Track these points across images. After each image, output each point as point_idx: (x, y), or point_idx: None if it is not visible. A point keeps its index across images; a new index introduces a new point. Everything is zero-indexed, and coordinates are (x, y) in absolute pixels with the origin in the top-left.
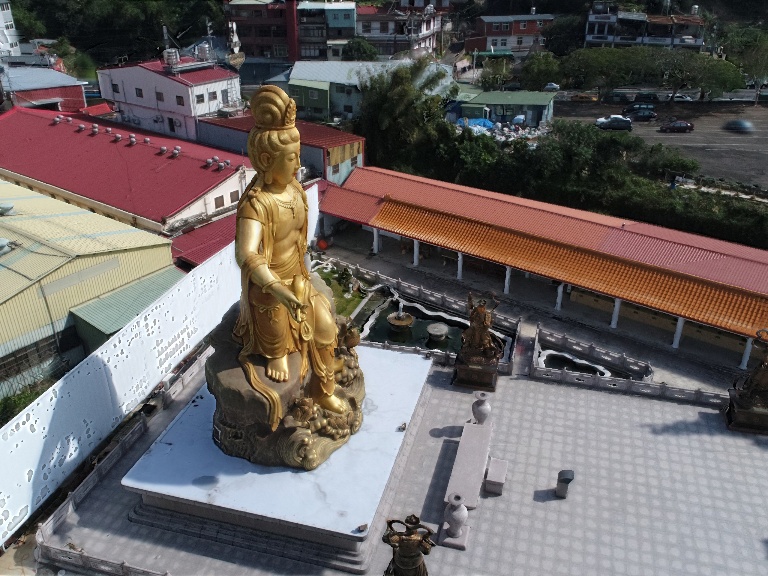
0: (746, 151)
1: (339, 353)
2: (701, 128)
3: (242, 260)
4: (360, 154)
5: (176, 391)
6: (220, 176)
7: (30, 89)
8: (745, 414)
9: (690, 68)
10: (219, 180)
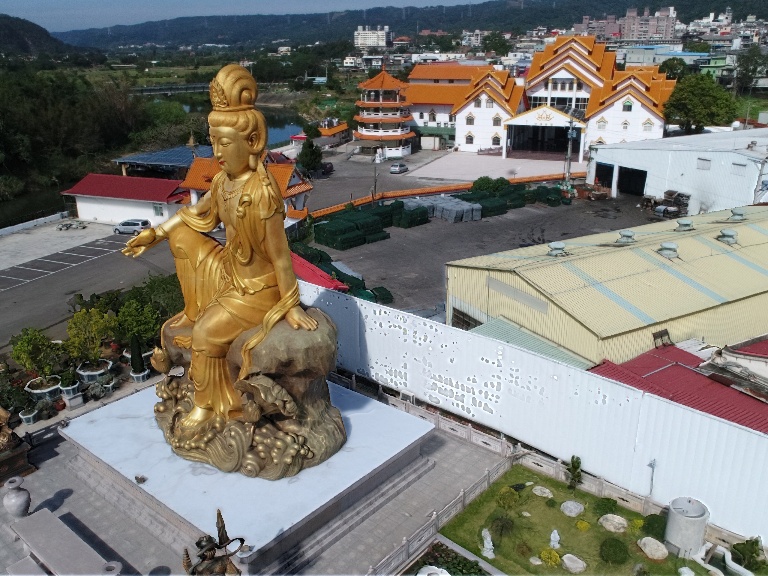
0: None
1: None
2: None
3: None
4: None
5: None
6: None
7: None
8: None
9: None
10: None
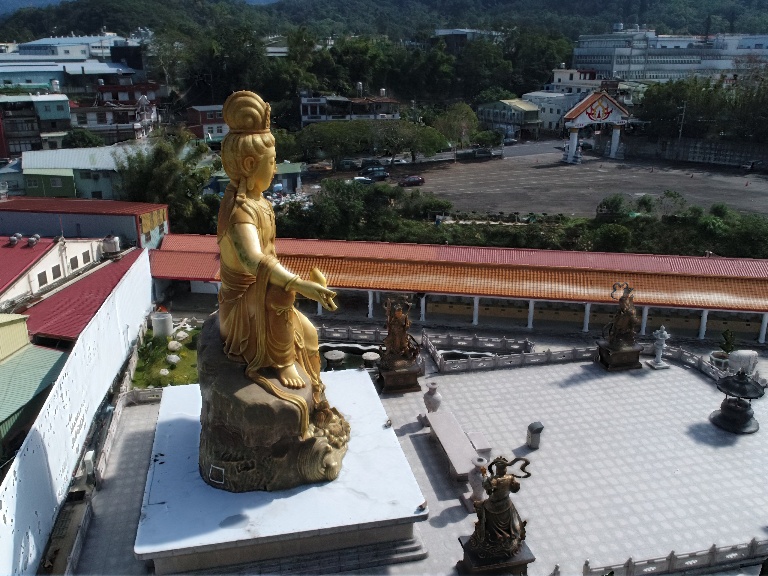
0: (473, 193)
1: None
2: (428, 181)
3: (256, 262)
4: (165, 221)
5: (102, 469)
6: (35, 251)
7: None
8: (617, 356)
9: (406, 134)
10: (38, 254)
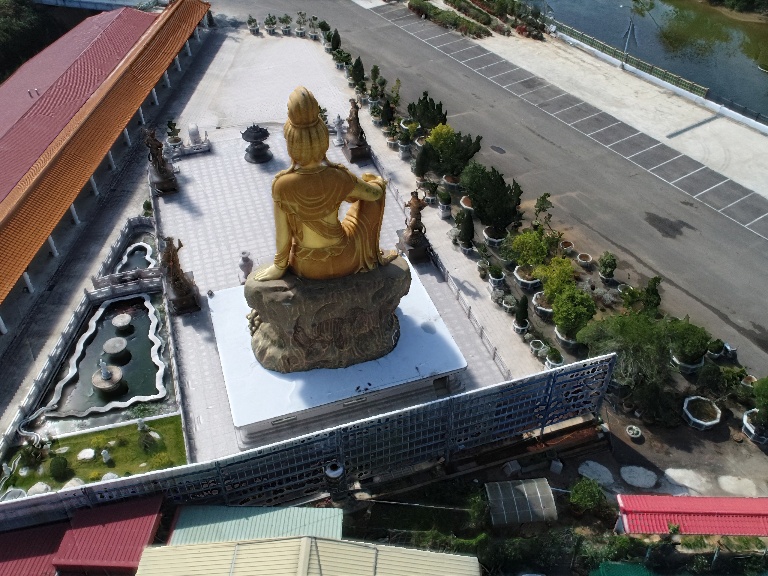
0: None
1: None
2: None
3: None
4: None
5: None
6: None
7: None
8: None
9: None
10: None
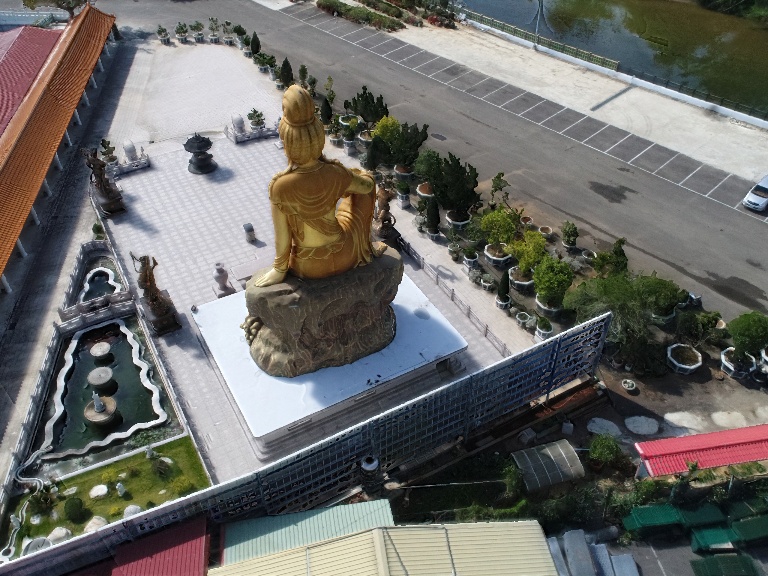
0: None
1: None
2: None
3: None
4: None
5: None
6: None
7: None
8: None
9: None
10: None
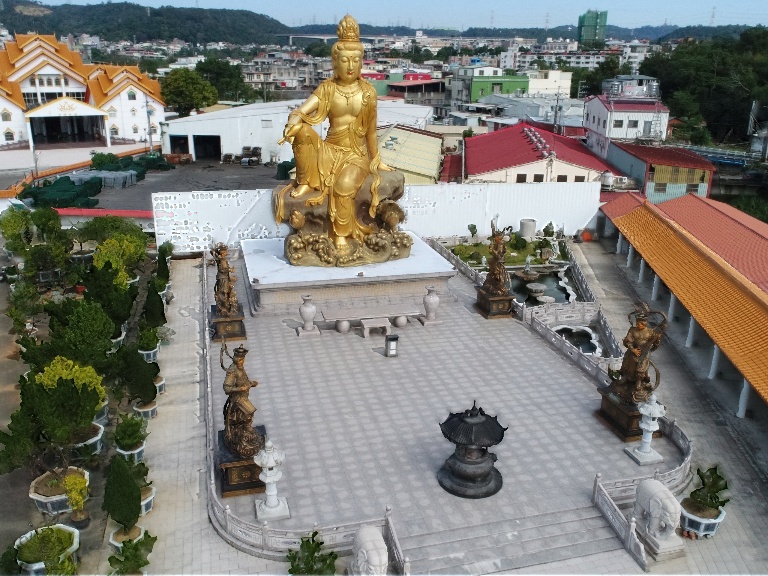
0: None
1: (383, 228)
2: None
3: None
4: (705, 184)
5: None
6: None
7: (577, 126)
8: (607, 401)
9: None
10: None
